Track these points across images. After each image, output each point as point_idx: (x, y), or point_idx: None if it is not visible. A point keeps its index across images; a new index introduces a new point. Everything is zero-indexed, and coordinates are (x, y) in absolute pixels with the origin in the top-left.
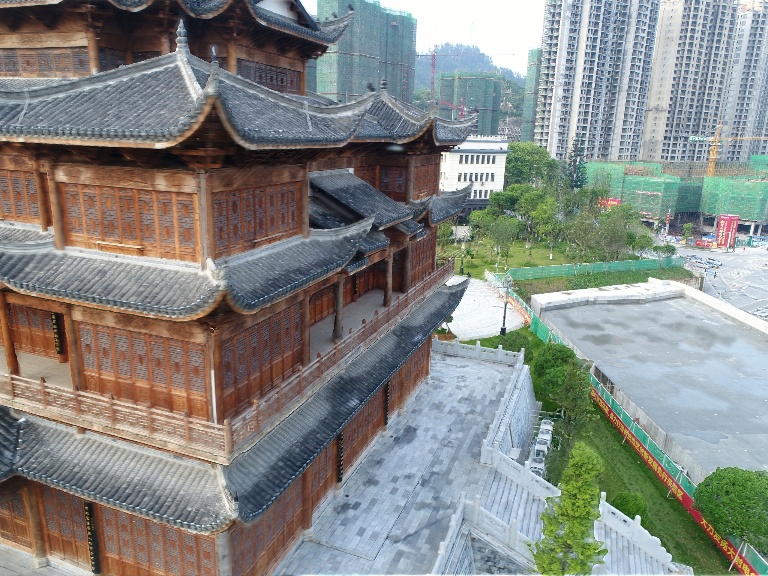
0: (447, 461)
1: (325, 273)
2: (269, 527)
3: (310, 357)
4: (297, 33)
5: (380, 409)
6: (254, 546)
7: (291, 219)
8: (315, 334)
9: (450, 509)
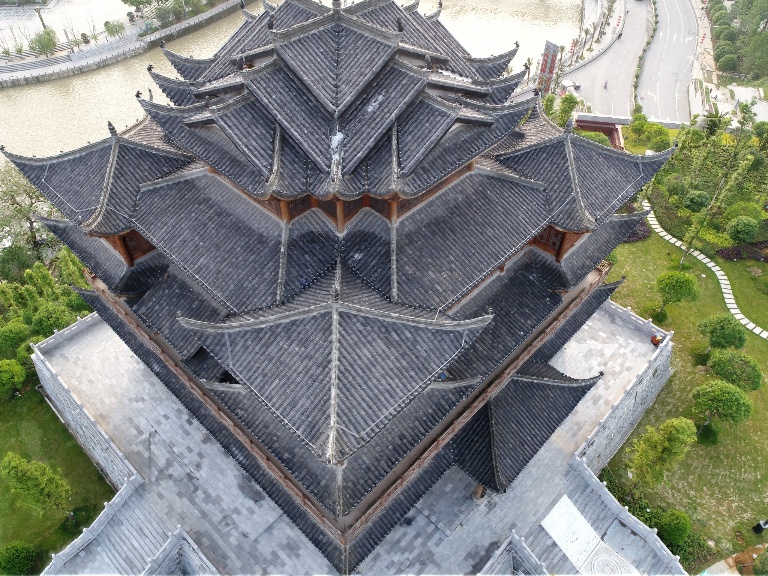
0: (204, 507)
1: None
2: None
3: None
4: None
5: None
6: None
7: None
8: None
9: (155, 480)
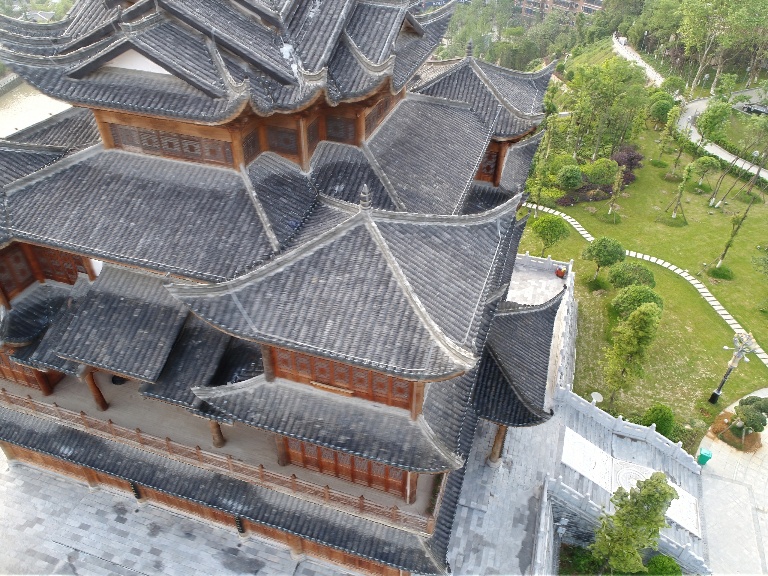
0: None
1: None
2: None
3: (67, 393)
4: (128, 110)
5: None
6: None
7: None
8: (127, 389)
9: None
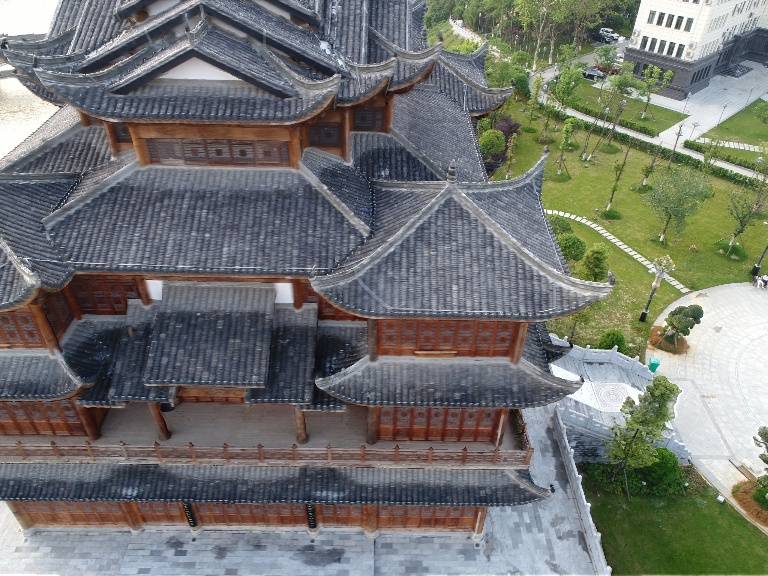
0: None
1: (12, 398)
2: (69, 504)
3: (117, 432)
4: (193, 120)
5: (301, 512)
6: (49, 505)
7: (29, 336)
8: (181, 413)
9: None
